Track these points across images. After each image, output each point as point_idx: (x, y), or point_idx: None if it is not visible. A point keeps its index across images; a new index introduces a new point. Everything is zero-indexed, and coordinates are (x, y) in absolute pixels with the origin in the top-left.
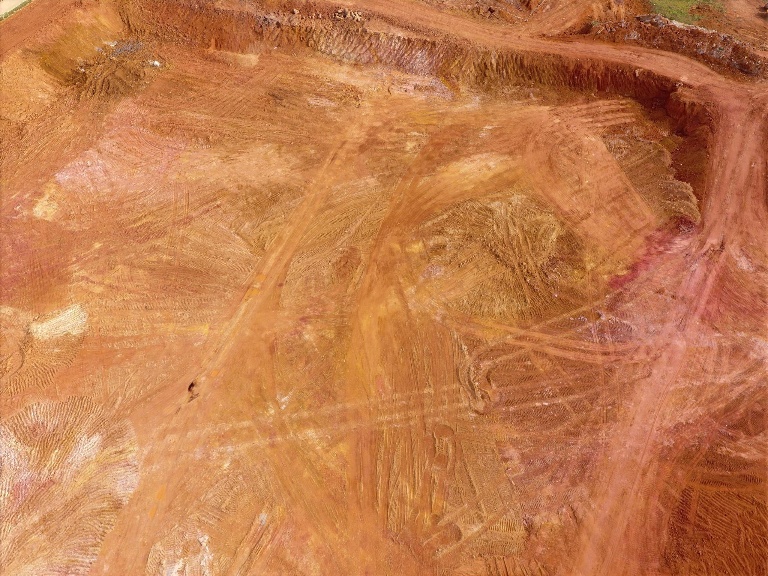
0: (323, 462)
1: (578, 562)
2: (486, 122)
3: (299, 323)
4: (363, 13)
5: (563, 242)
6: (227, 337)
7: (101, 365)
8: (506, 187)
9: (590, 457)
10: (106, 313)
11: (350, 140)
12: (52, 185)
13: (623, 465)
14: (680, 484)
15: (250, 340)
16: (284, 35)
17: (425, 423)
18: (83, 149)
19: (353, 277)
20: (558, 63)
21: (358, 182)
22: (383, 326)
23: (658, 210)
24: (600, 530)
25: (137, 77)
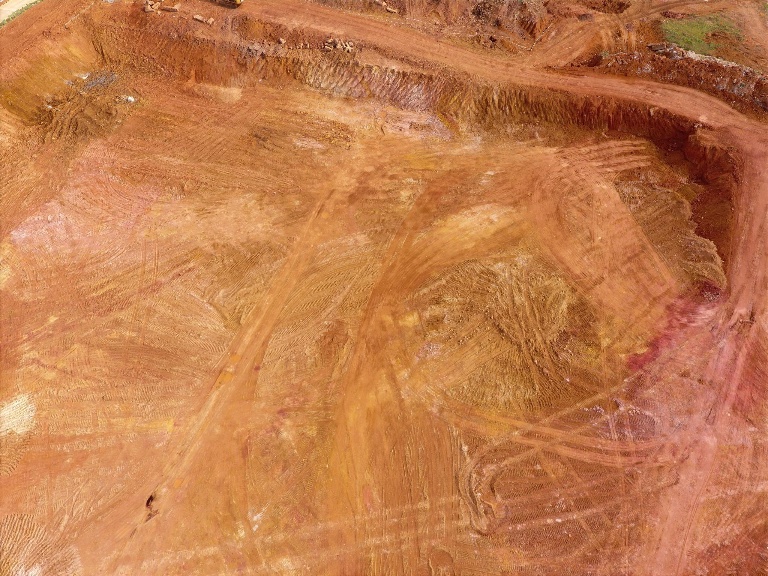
0: None
1: None
2: (488, 167)
3: (276, 417)
4: (354, 43)
5: (574, 312)
6: (194, 436)
7: (47, 473)
8: (510, 245)
9: None
10: (57, 405)
11: (339, 189)
12: (6, 245)
13: None
14: None
15: (220, 440)
16: (269, 67)
17: (419, 548)
18: (44, 201)
19: (339, 358)
20: (566, 100)
21: (347, 239)
22: (372, 420)
23: (679, 272)
24: None
25: (108, 115)
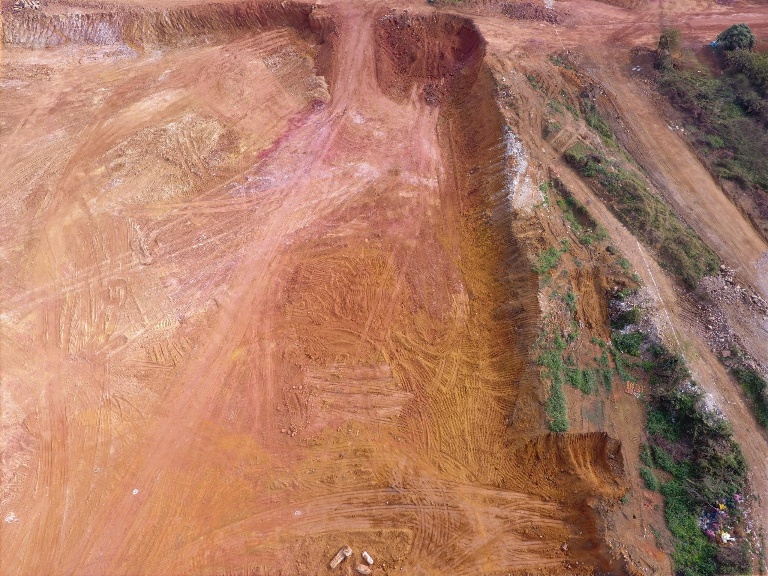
0: (13, 331)
1: (216, 328)
2: (166, 68)
3: None
4: (40, 1)
5: (224, 138)
6: None
7: None
8: (180, 111)
9: (231, 267)
10: None
11: (40, 107)
12: None
13: (255, 264)
14: (294, 263)
15: None
16: None
17: (102, 283)
18: None
19: (41, 204)
20: (220, 10)
21: (47, 136)
22: (68, 231)
23: (300, 100)
24: (234, 306)
25: None
